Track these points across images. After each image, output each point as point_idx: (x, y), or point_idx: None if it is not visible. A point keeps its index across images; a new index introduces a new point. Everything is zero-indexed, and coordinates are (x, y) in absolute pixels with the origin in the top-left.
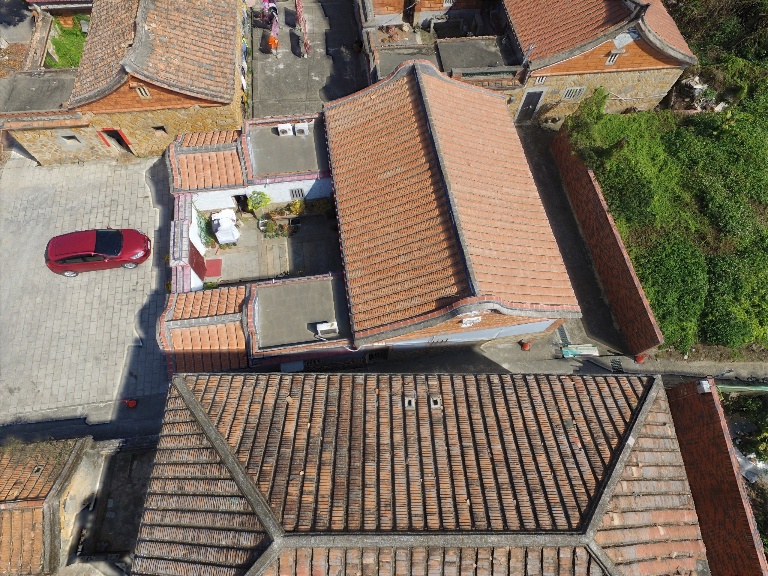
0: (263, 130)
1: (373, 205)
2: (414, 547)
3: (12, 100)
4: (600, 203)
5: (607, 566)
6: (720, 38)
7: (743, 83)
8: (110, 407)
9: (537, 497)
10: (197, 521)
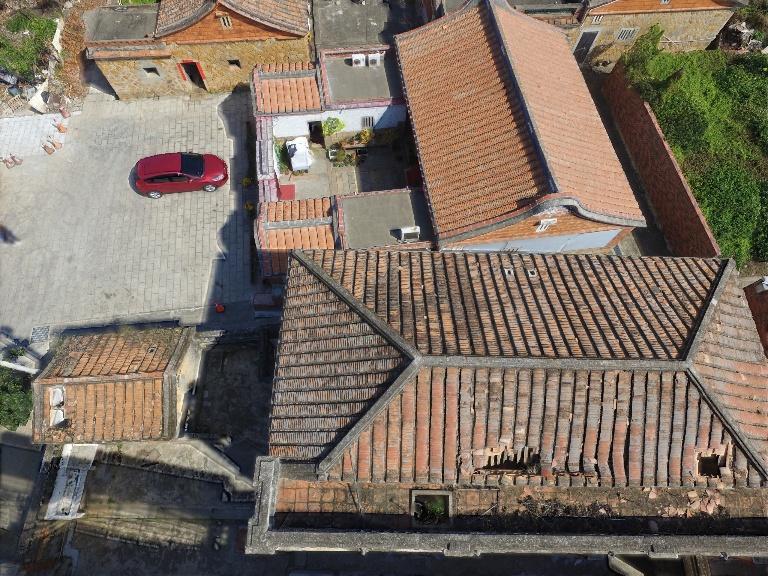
0: (337, 61)
1: (450, 123)
2: (535, 369)
3: (100, 31)
4: (656, 132)
5: (705, 388)
6: None
7: None
8: (200, 312)
9: (637, 337)
10: (332, 358)
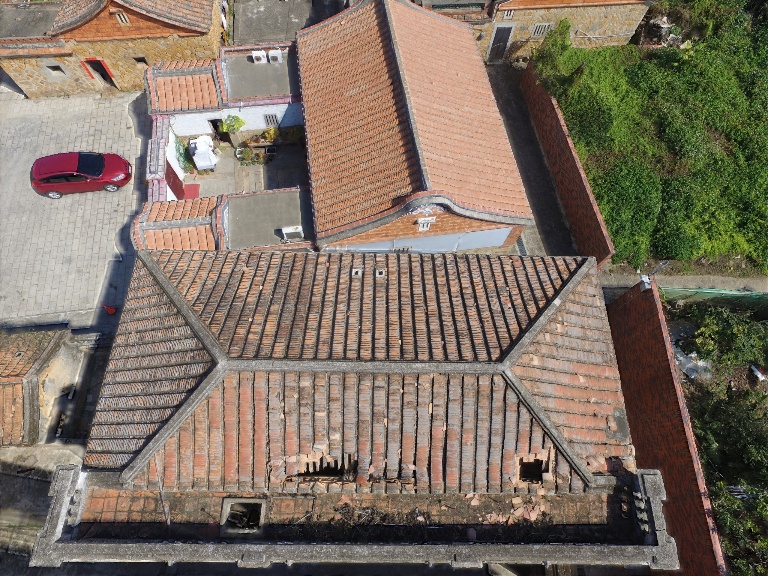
0: (239, 58)
1: (339, 120)
2: (346, 373)
3: None
4: (561, 128)
5: (521, 391)
6: None
7: (708, 21)
8: (91, 314)
9: (463, 339)
10: (155, 362)
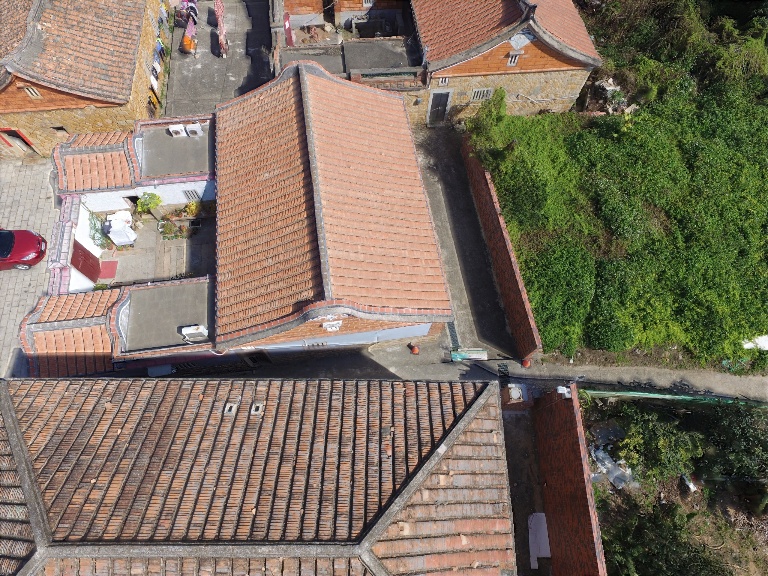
0: (157, 131)
1: (250, 207)
2: (184, 557)
3: None
4: (494, 206)
5: None
6: (637, 39)
7: (654, 85)
8: None
9: (326, 506)
10: None
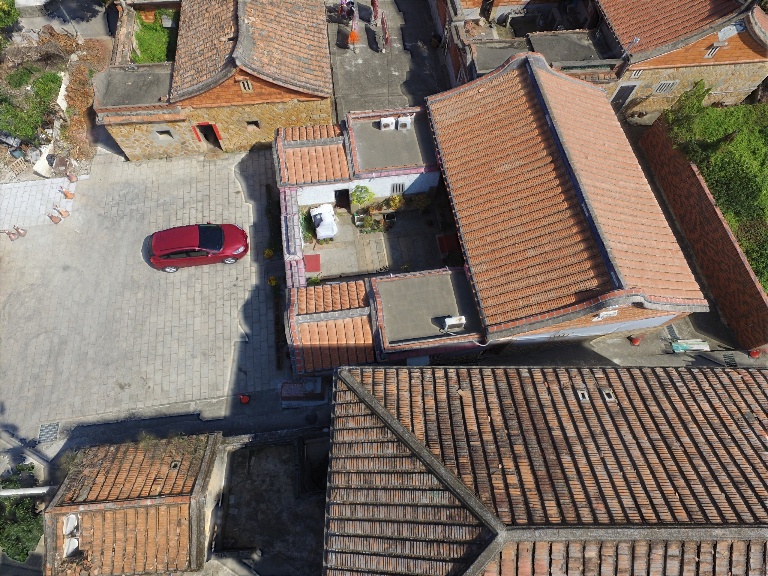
0: (364, 124)
1: (492, 199)
2: (636, 541)
3: (110, 94)
4: (707, 197)
5: None
6: None
7: None
8: (222, 403)
9: (745, 490)
10: (395, 515)
